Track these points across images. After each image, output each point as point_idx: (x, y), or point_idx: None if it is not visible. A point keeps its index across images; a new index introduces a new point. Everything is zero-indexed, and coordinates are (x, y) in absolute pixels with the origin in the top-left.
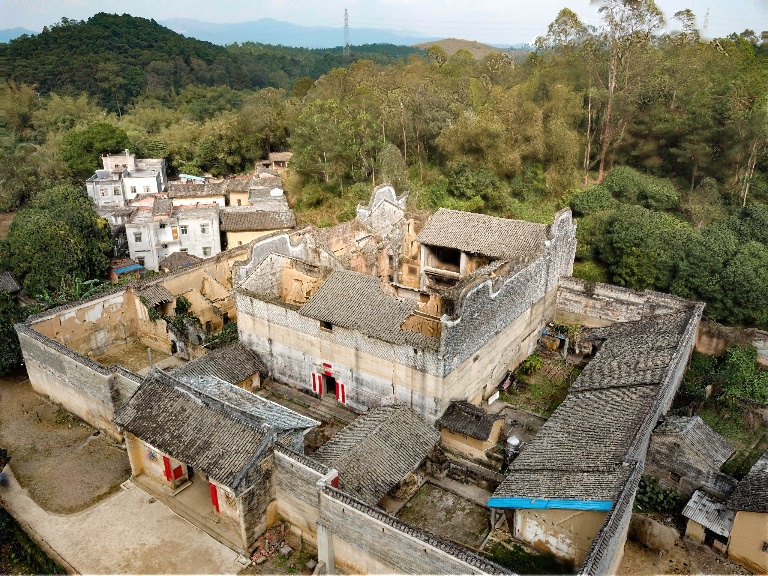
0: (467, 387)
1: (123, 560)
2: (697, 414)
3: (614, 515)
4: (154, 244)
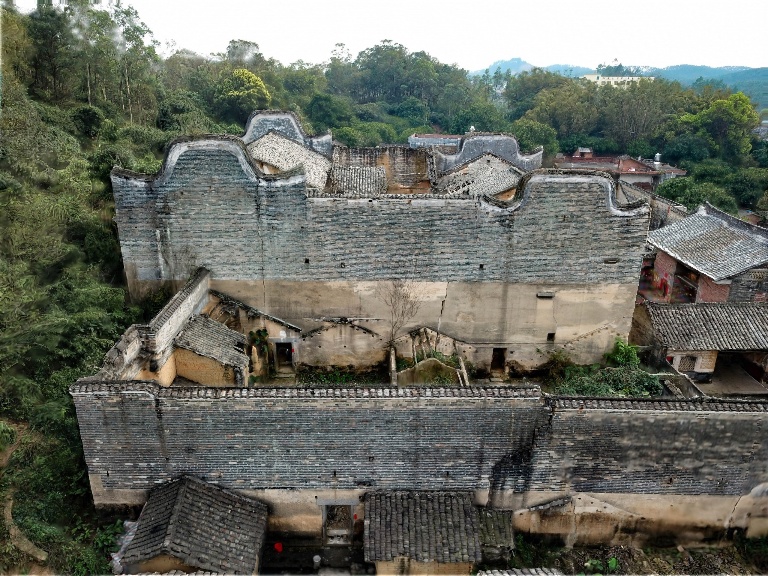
0: None
1: None
2: None
3: None
4: None
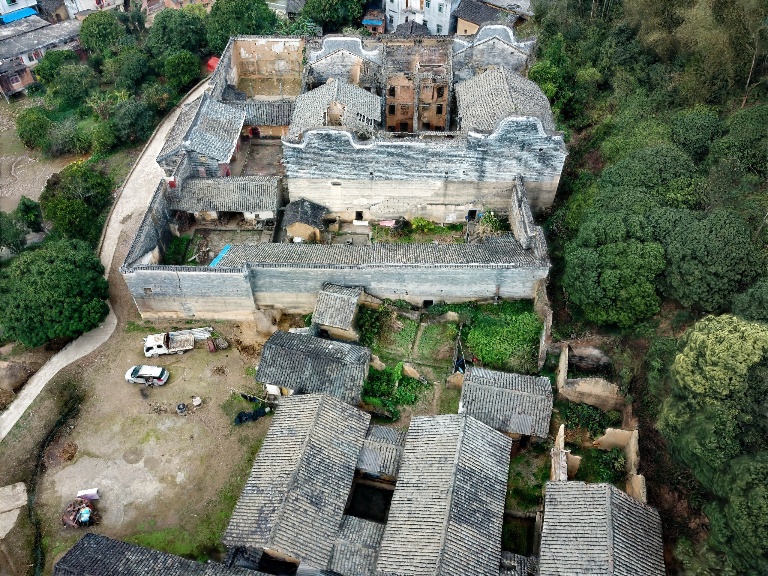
0: (327, 199)
1: (150, 172)
2: (433, 323)
3: (185, 266)
4: (400, 8)
